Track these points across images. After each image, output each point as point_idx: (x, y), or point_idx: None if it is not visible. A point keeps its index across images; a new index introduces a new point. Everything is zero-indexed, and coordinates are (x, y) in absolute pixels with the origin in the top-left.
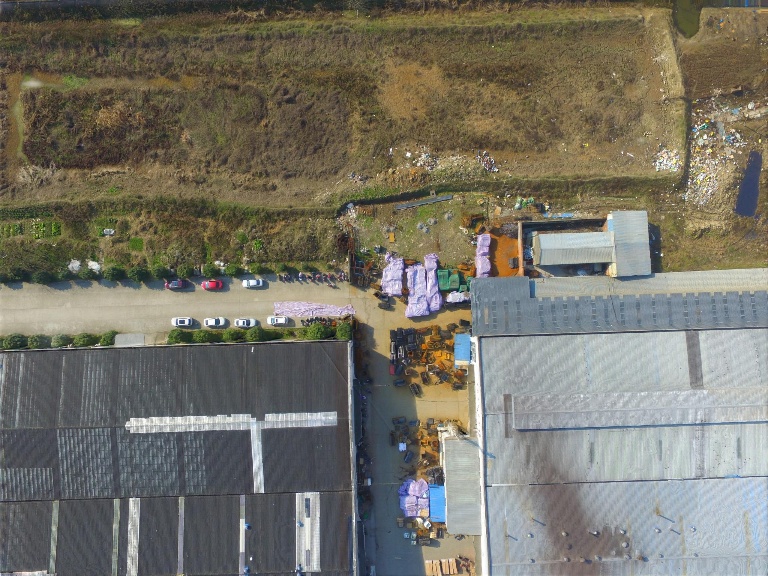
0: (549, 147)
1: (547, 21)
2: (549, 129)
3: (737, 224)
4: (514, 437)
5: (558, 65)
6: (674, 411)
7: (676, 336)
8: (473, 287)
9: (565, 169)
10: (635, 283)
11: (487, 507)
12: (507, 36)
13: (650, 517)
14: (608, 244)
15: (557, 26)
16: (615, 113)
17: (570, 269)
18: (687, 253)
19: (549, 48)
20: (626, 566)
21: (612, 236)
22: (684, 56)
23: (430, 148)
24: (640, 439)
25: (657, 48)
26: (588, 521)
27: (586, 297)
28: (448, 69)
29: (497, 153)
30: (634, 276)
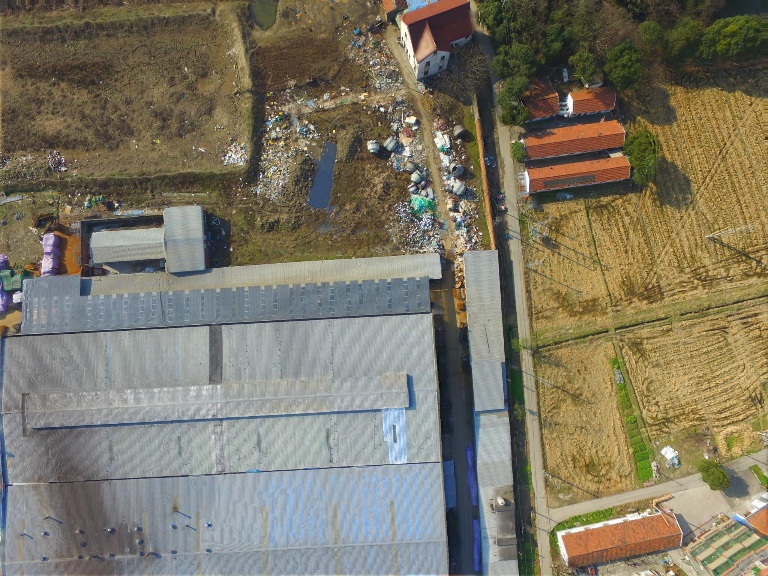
0: (120, 144)
1: (115, 18)
2: (118, 126)
3: (310, 216)
4: (32, 436)
5: (131, 62)
6: (186, 406)
7: (199, 331)
8: (24, 287)
9: (133, 166)
10: (191, 279)
11: (5, 506)
12: (79, 35)
13: (167, 513)
14: (158, 240)
15: (126, 23)
16: (186, 108)
17: (138, 266)
18: (258, 247)
19: (122, 45)
20: (140, 563)
21: (163, 232)
22: (258, 49)
23: (2, 149)
24: (158, 435)
25: (229, 41)
26: (105, 518)
27: (135, 294)
28: (21, 70)
29: (69, 152)
30: (190, 272)
